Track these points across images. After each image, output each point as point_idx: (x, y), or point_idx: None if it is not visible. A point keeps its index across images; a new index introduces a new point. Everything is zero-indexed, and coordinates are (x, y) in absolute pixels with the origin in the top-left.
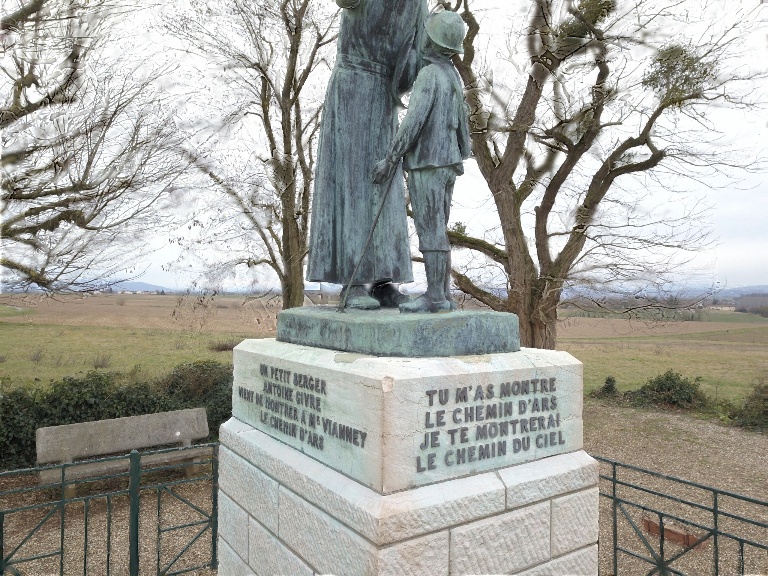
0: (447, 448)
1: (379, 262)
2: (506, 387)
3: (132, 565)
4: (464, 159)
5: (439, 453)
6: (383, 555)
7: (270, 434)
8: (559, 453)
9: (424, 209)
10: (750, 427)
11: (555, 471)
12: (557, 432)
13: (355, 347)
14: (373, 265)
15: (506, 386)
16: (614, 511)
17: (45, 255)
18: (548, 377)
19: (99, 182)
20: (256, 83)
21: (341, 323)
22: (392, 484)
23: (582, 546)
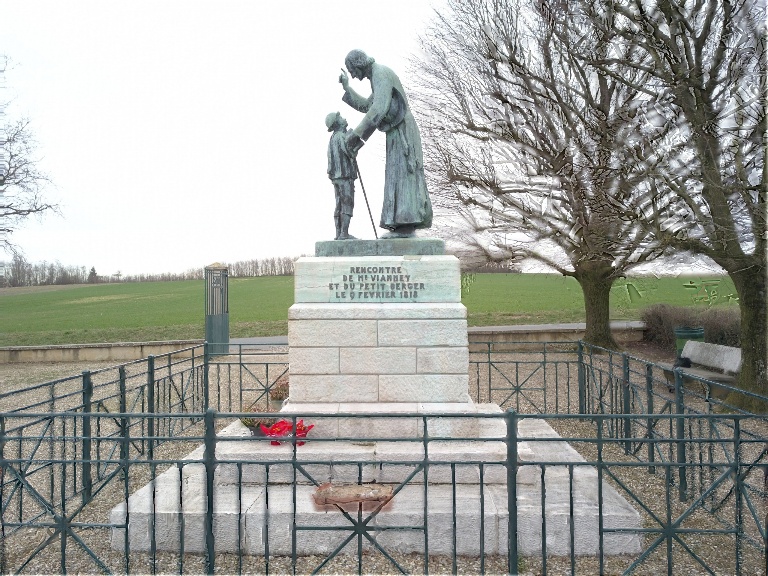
0: None
1: None
2: None
3: None
4: None
5: None
6: None
7: None
8: None
9: None
10: None
11: None
12: None
13: None
14: None
15: None
16: (426, 480)
17: None
18: None
19: None
20: None
21: None
22: None
23: None
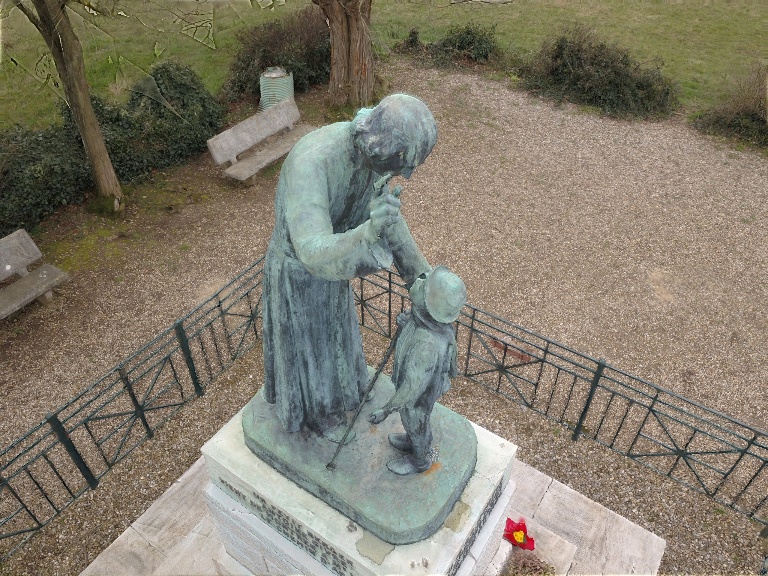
0: None
1: (348, 398)
2: None
3: (86, 476)
4: None
5: None
6: None
7: (278, 532)
8: (498, 500)
9: (416, 426)
10: (535, 90)
11: (498, 518)
12: None
13: (368, 529)
14: (342, 400)
15: (480, 517)
16: (470, 335)
17: None
18: (500, 480)
19: None
20: None
21: (348, 505)
22: None
23: None
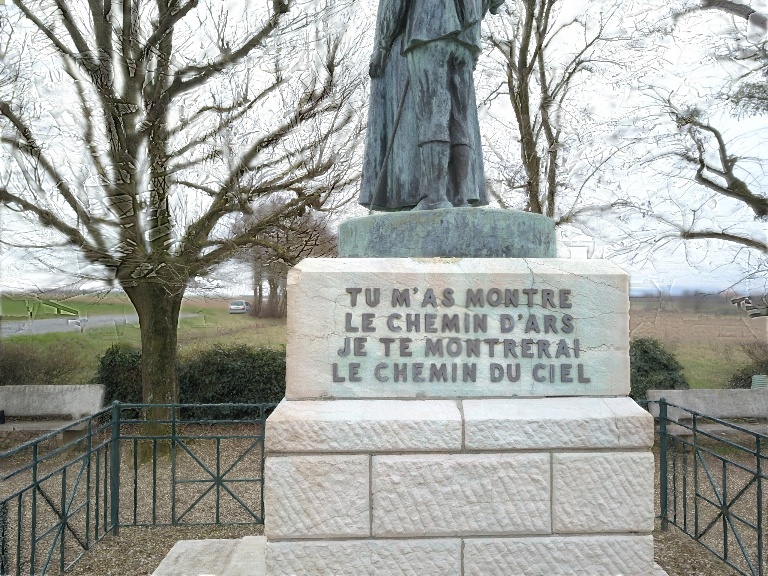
0: (379, 359)
1: (424, 177)
2: (476, 294)
3: None
4: (470, 27)
5: (366, 364)
6: (271, 463)
7: None
8: (580, 394)
9: (418, 95)
10: None
11: (560, 414)
12: (575, 365)
13: None
14: (419, 182)
15: (476, 293)
16: None
17: (285, 234)
18: (556, 288)
19: (327, 168)
20: (502, 61)
21: None
22: (298, 389)
23: (618, 531)
